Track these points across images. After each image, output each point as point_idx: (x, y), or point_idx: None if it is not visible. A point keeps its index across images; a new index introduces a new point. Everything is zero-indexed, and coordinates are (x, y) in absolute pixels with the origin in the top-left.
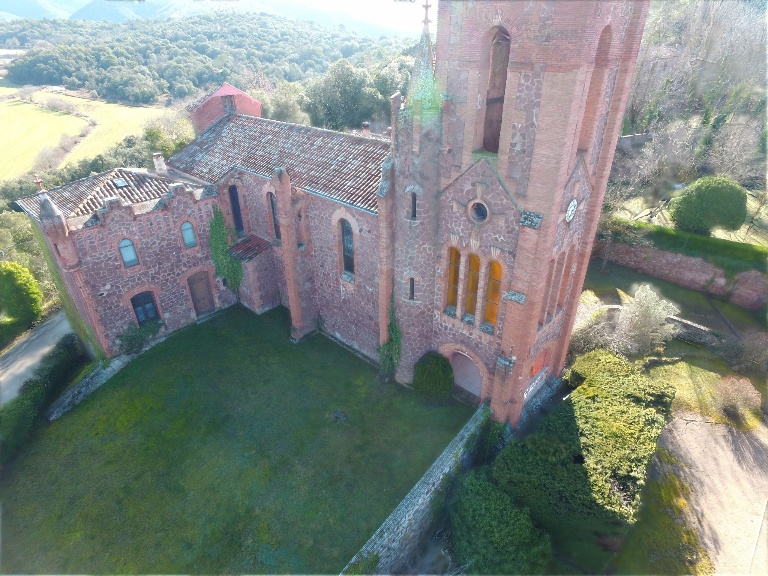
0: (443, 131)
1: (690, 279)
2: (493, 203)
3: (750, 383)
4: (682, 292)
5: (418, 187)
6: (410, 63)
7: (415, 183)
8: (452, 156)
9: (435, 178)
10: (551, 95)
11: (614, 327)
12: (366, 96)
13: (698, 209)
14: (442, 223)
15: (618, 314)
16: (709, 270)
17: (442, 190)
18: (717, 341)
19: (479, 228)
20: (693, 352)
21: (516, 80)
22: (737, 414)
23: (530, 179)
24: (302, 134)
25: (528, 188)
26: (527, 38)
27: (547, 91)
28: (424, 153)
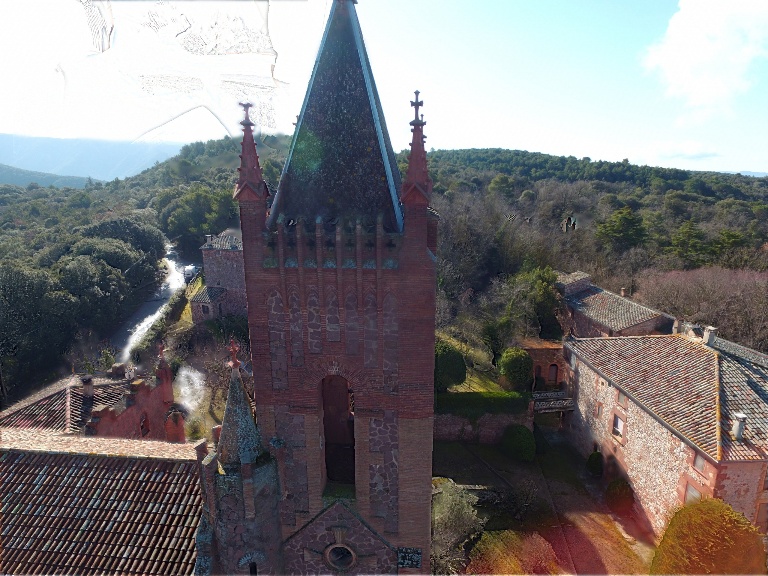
0: (280, 480)
1: (448, 433)
2: (358, 545)
3: (540, 536)
4: (447, 448)
5: (257, 554)
6: (100, 247)
7: (252, 551)
8: (294, 502)
9: (276, 532)
10: (409, 439)
11: (432, 533)
12: (52, 302)
13: (436, 374)
14: (290, 575)
15: (433, 520)
16: (458, 421)
17: (285, 539)
18: (497, 497)
19: (344, 574)
20: (486, 515)
21: (366, 425)
22: (542, 569)
23: (400, 517)
24: (4, 465)
25: (399, 525)
26: (372, 388)
27: (404, 435)
28: (260, 514)
